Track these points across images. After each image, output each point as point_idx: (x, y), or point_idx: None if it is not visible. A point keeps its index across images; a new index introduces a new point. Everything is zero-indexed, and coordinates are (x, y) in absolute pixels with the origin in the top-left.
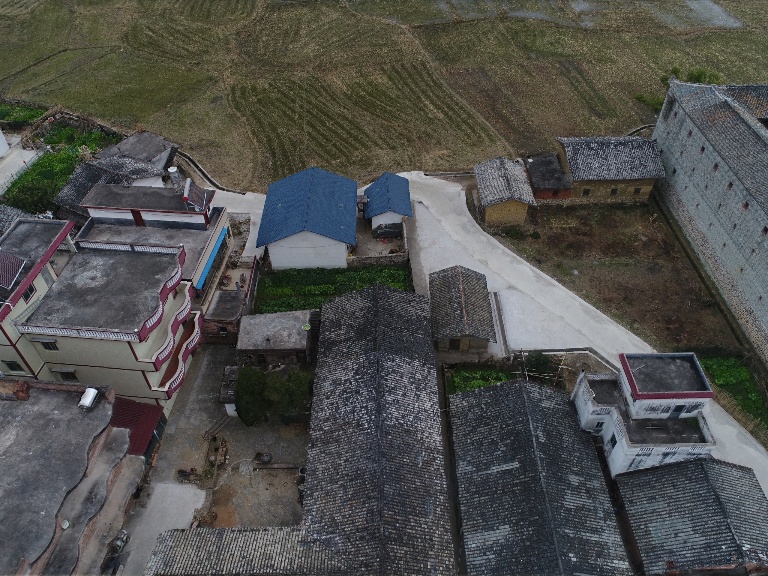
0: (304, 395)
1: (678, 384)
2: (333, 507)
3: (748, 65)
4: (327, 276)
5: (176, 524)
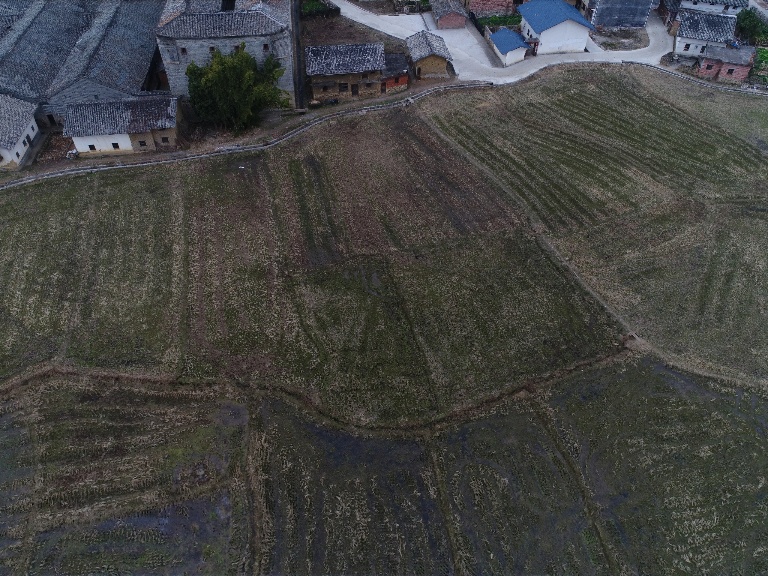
0: None
1: None
2: None
3: (6, 283)
4: None
5: None
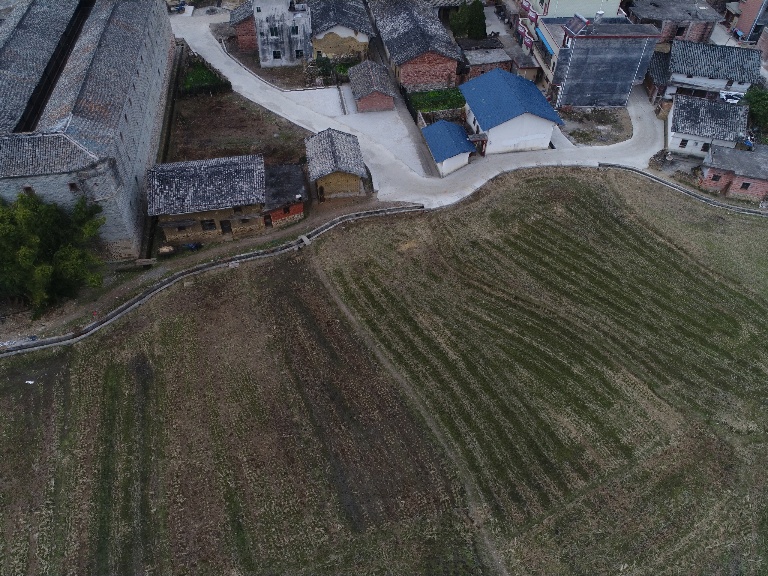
0: None
1: None
2: (421, 4)
3: None
4: None
5: (488, 28)
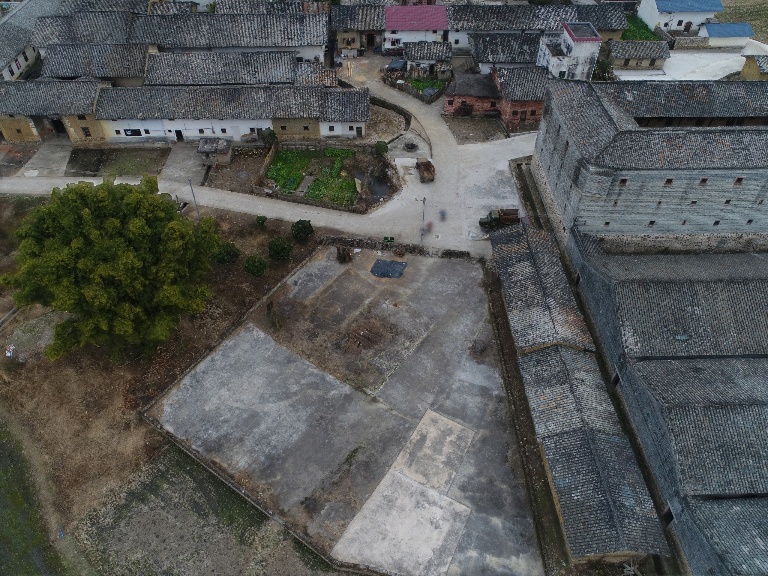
0: (545, 0)
1: (578, 34)
2: None
3: None
4: (642, 27)
5: None
